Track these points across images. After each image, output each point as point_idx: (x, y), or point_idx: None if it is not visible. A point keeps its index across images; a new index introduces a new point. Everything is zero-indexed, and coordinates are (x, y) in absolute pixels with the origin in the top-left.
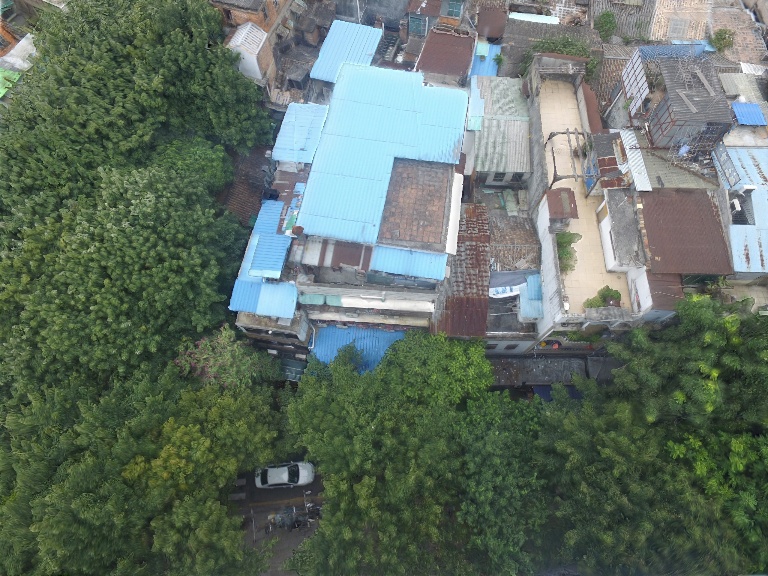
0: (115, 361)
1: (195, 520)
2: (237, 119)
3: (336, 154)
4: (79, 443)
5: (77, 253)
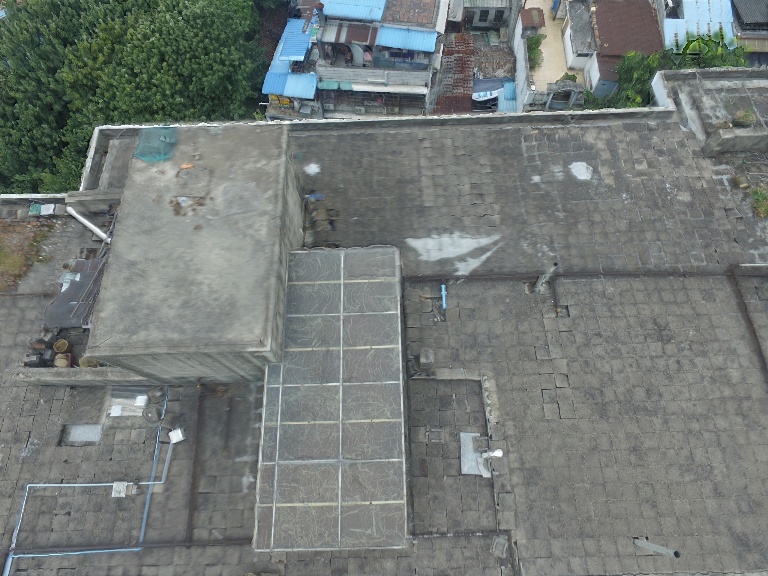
0: None
1: None
2: None
3: None
4: None
5: (141, 43)
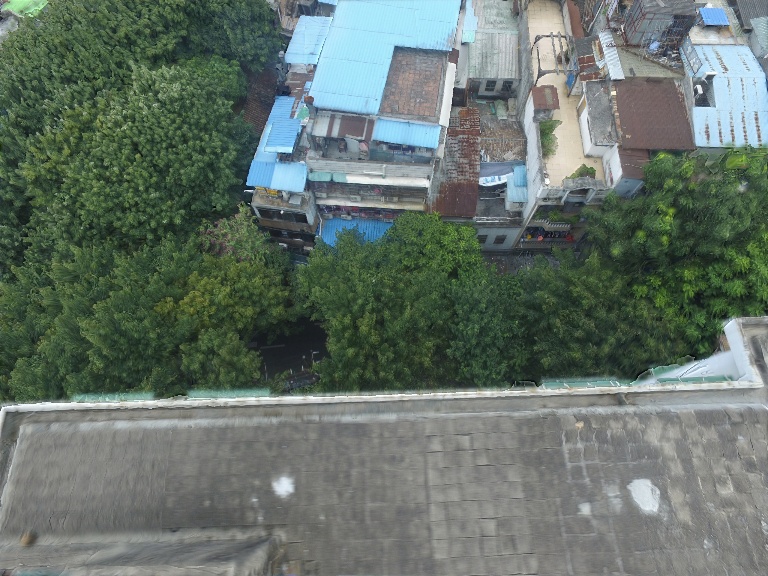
0: (144, 230)
1: (218, 344)
2: (251, 36)
3: (343, 43)
4: (117, 283)
5: (112, 131)
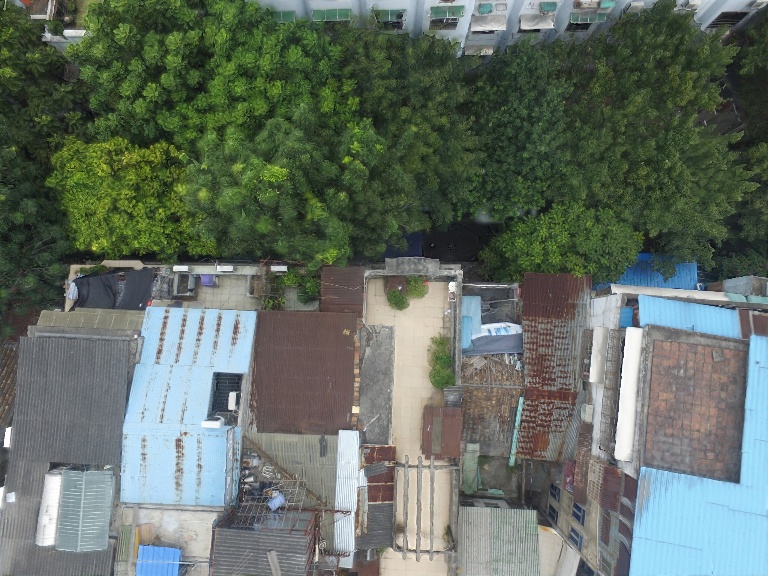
0: None
1: None
2: None
3: None
4: None
5: None
